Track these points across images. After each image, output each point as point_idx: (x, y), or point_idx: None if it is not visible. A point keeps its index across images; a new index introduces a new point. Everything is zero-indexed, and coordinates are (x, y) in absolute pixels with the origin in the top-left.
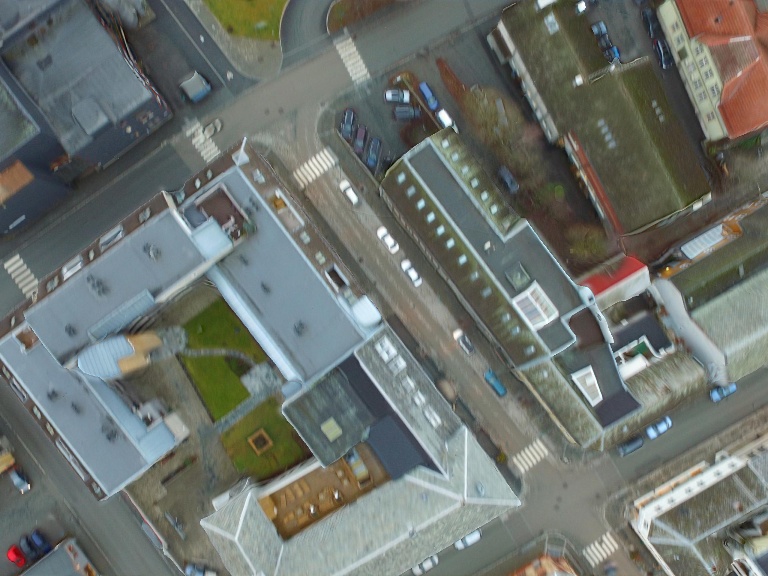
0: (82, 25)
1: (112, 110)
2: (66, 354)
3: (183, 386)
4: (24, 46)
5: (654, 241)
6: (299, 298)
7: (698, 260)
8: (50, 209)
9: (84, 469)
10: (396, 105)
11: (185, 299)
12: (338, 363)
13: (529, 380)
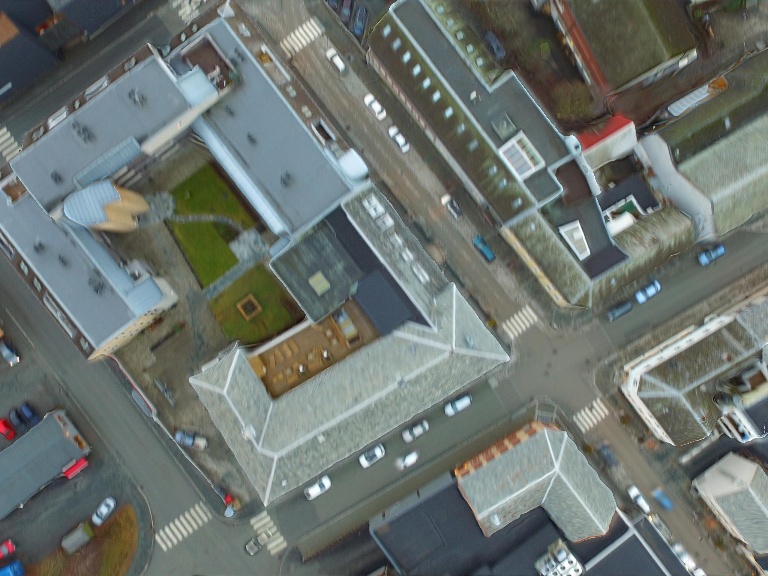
0: None
1: None
2: (52, 202)
3: (171, 252)
4: None
5: (641, 106)
6: (285, 149)
7: (684, 115)
8: (37, 80)
9: (72, 323)
10: None
11: (172, 160)
12: (325, 215)
13: (517, 236)
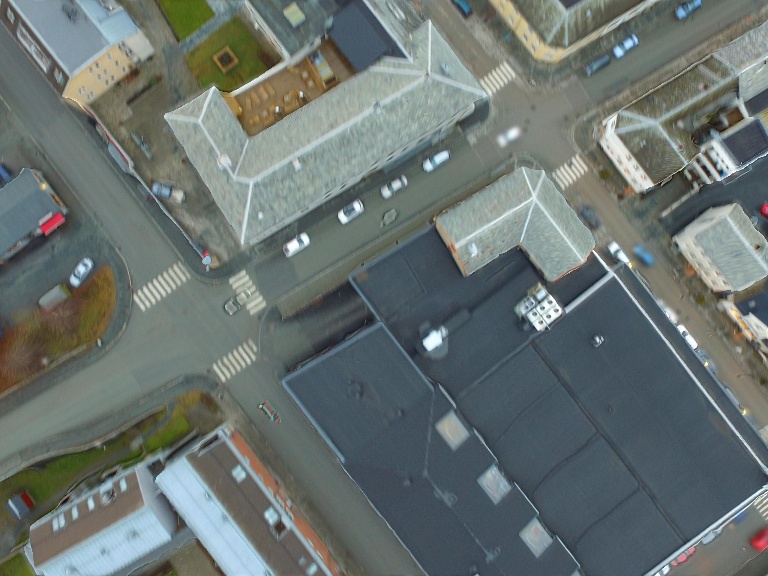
0: None
1: None
2: None
3: (147, 5)
4: None
5: None
6: None
7: None
8: None
9: (45, 53)
10: None
11: None
12: None
13: None
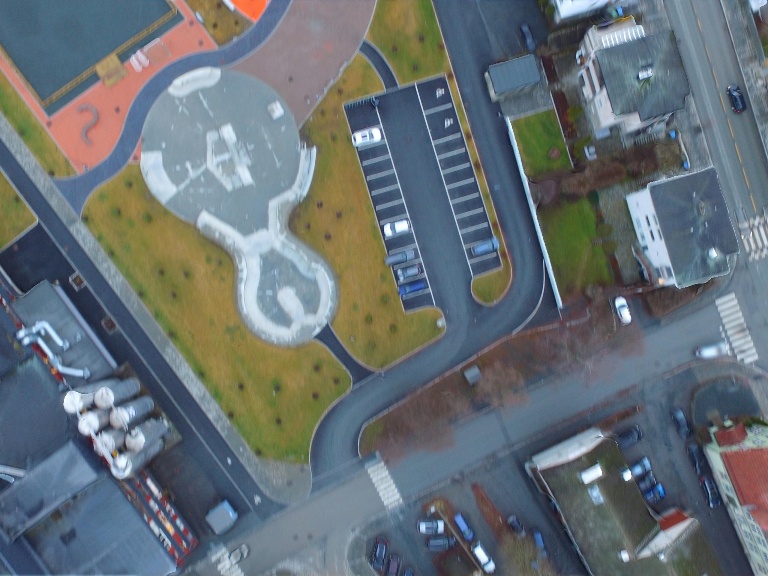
0: (107, 499)
1: None
2: None
3: None
4: (47, 522)
5: None
6: None
7: None
8: None
9: None
10: (430, 538)
11: None
12: None
13: None
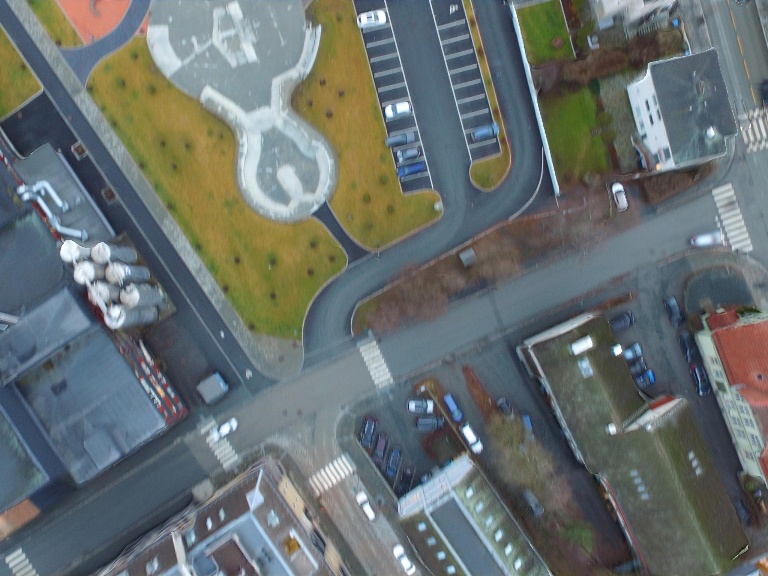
0: (100, 351)
1: (125, 440)
2: None
3: None
4: (39, 371)
5: None
6: None
7: None
8: None
9: None
10: (419, 416)
11: None
12: None
13: None
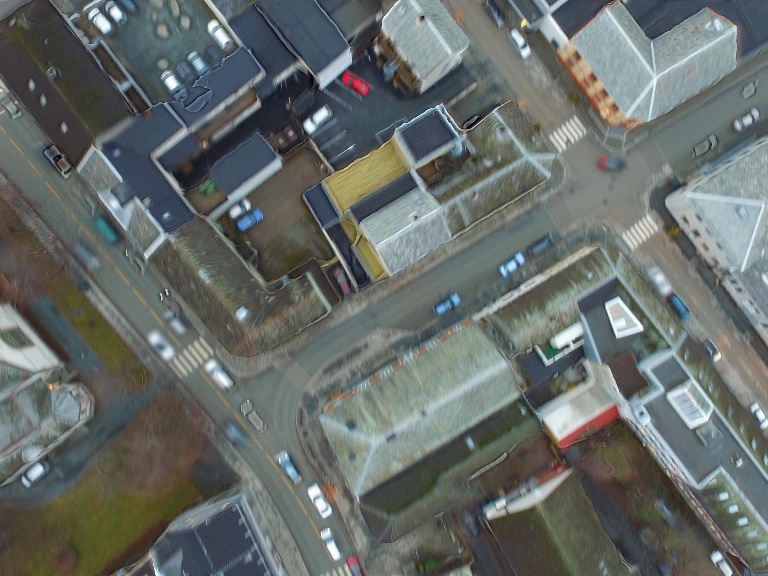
0: None
1: None
2: None
3: None
4: None
5: (519, 457)
6: None
7: None
8: None
9: None
10: None
11: None
12: None
13: None
